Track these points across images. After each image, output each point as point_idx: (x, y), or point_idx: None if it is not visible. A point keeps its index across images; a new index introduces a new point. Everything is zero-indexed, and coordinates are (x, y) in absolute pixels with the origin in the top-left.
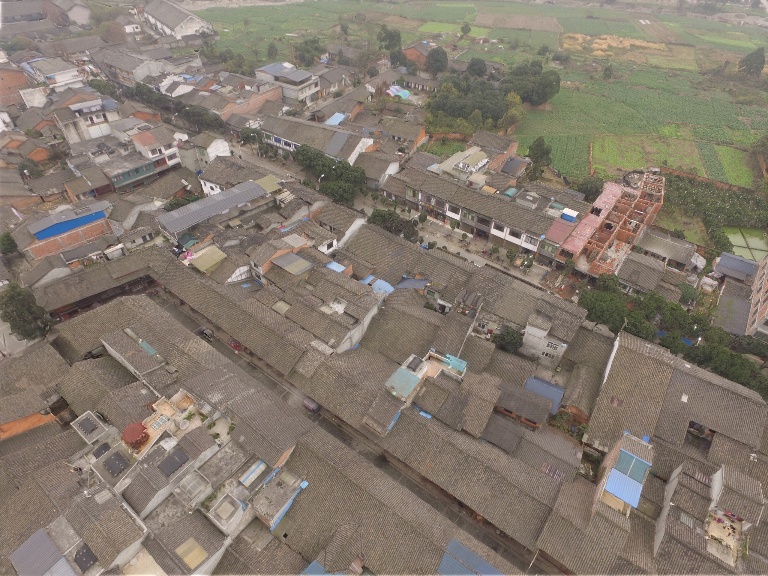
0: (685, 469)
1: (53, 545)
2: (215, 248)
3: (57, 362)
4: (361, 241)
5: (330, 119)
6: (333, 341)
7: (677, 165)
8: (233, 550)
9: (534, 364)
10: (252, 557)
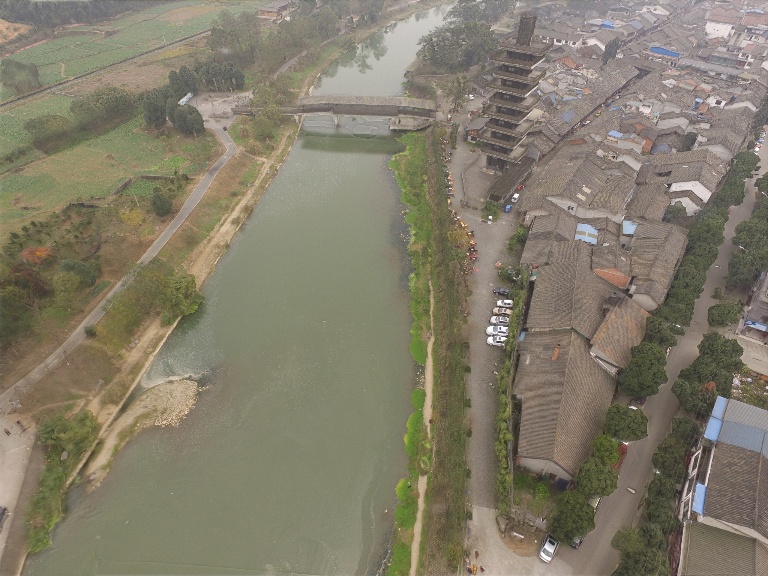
0: None
1: None
2: None
3: (597, 67)
4: None
5: None
6: None
7: None
8: (554, 92)
9: (680, 149)
10: None
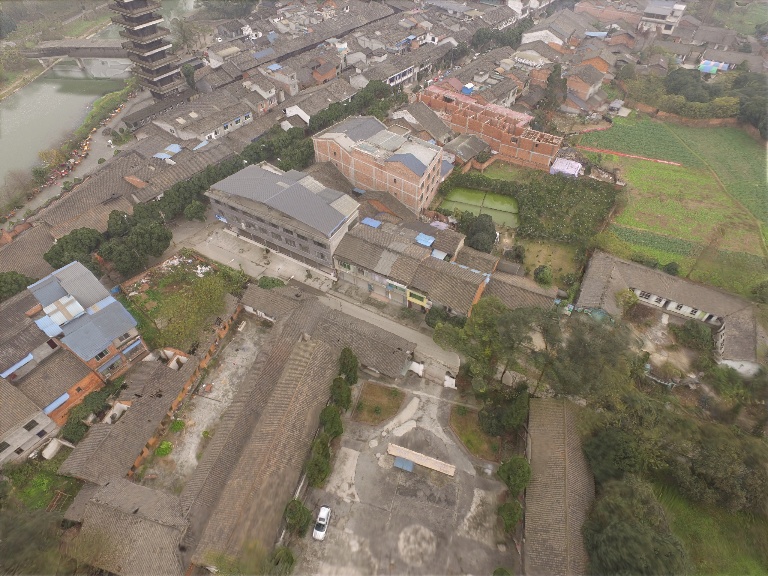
0: (280, 88)
1: (292, 7)
2: (418, 12)
3: None
4: (439, 45)
5: (595, 32)
6: (360, 35)
7: (657, 213)
8: (287, 32)
9: (348, 81)
10: (285, 35)
